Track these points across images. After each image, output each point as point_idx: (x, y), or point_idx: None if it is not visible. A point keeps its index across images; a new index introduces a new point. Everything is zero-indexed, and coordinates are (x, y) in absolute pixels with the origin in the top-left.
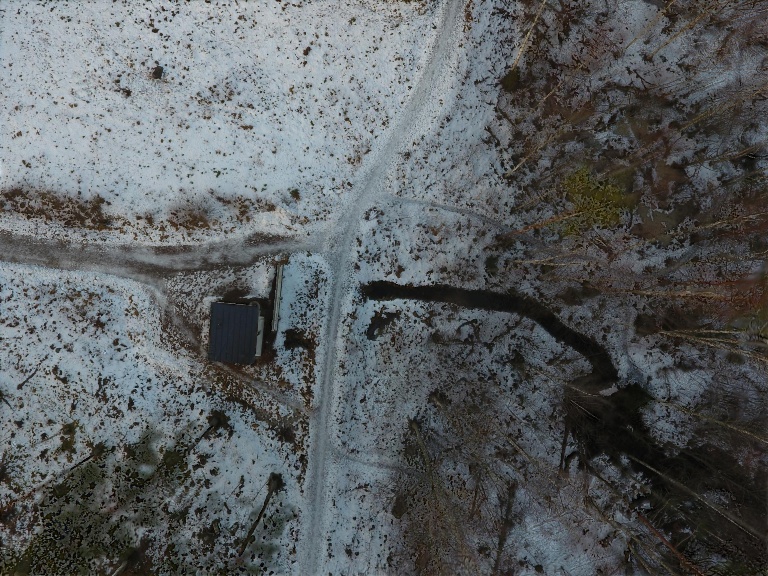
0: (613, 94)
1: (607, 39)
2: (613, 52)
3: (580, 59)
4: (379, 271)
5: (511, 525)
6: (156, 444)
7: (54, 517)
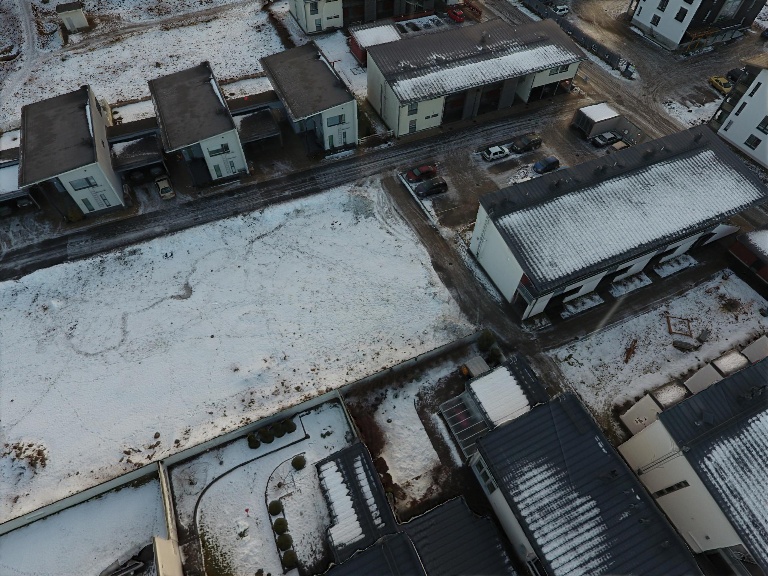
0: None
1: None
2: None
3: None
4: None
5: None
6: None
7: None
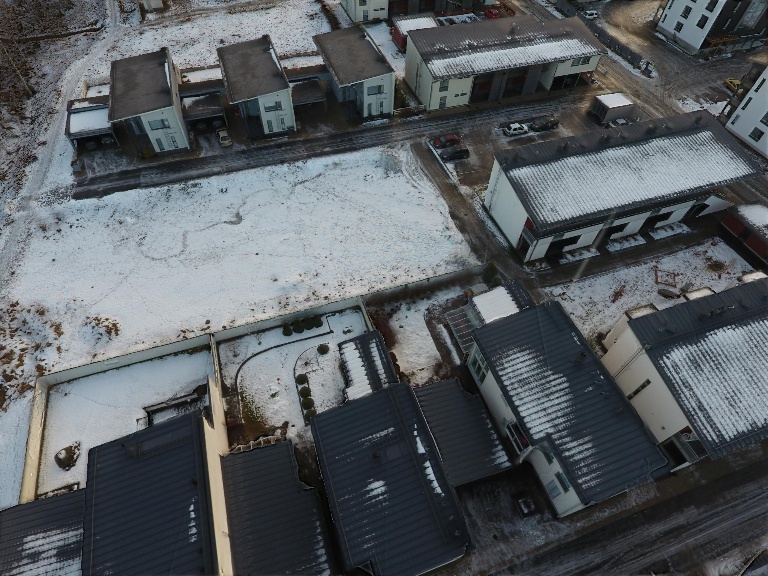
0: None
1: None
2: None
3: None
4: None
5: None
6: None
7: None
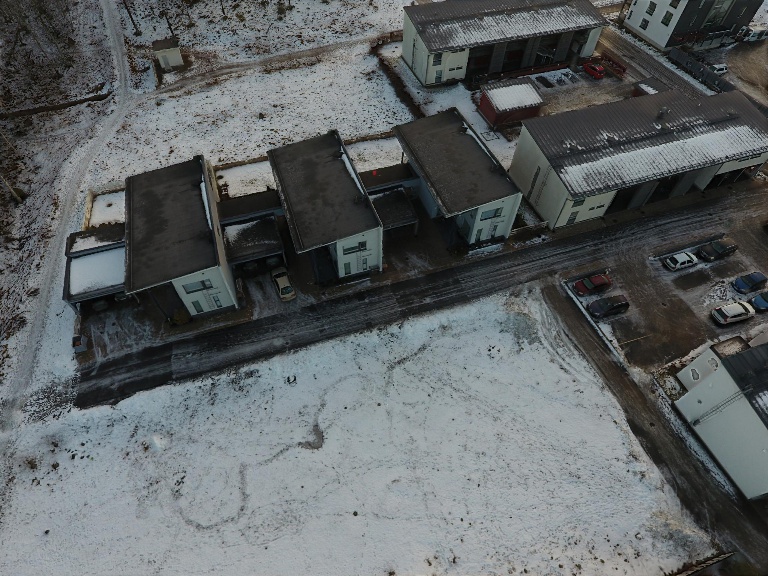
0: None
1: None
2: None
3: None
4: None
5: (8, 54)
6: (201, 27)
7: (234, 1)
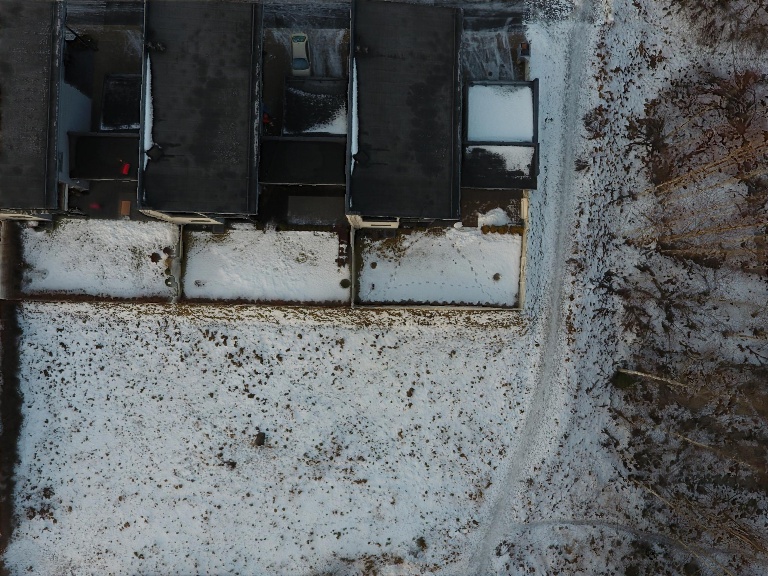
0: (728, 373)
1: (713, 318)
2: (722, 332)
3: (689, 344)
4: None
5: None
6: None
7: None
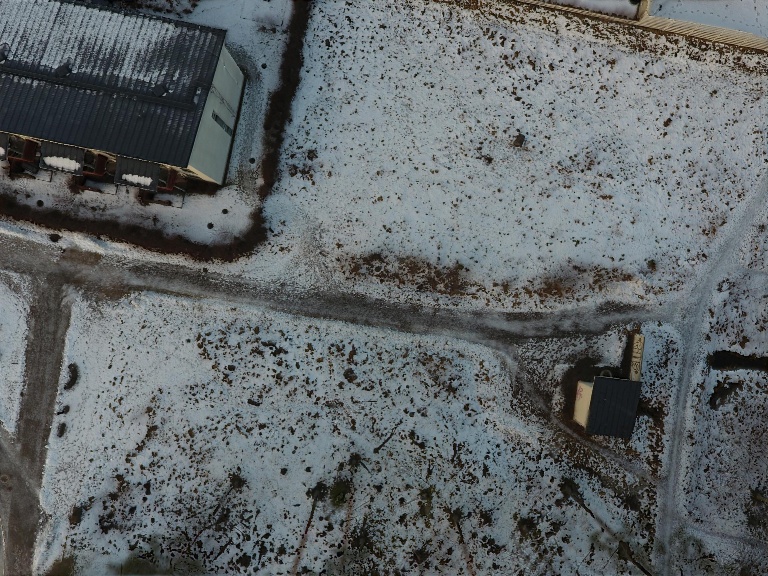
0: None
1: None
2: None
3: None
4: (724, 341)
5: None
6: (510, 510)
7: None
